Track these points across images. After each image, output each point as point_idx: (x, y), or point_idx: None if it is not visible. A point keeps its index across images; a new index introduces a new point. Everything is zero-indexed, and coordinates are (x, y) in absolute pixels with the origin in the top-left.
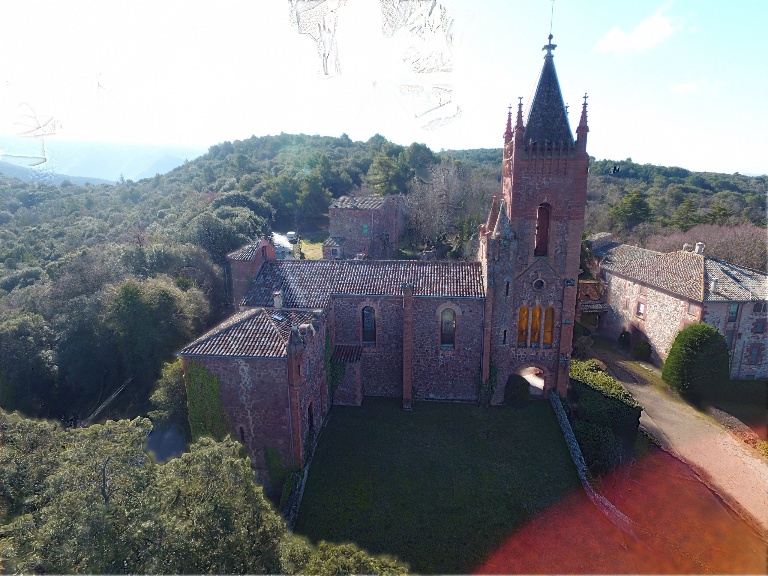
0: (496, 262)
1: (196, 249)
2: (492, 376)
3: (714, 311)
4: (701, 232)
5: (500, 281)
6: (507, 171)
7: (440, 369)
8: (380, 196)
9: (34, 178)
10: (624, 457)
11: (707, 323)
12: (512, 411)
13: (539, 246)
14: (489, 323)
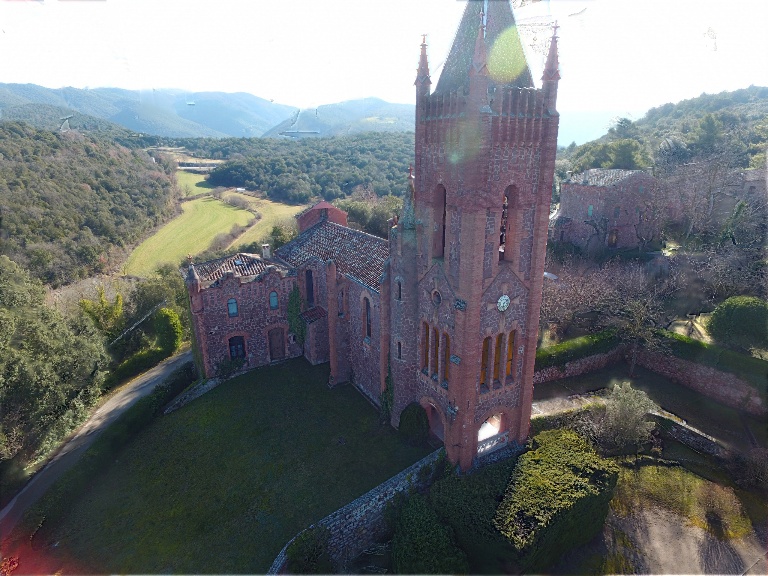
0: None
1: (381, 209)
2: (389, 391)
3: None
4: None
5: (392, 279)
6: None
7: (365, 361)
8: (631, 170)
9: (349, 147)
10: (420, 573)
11: None
12: (394, 441)
13: None
14: (382, 326)
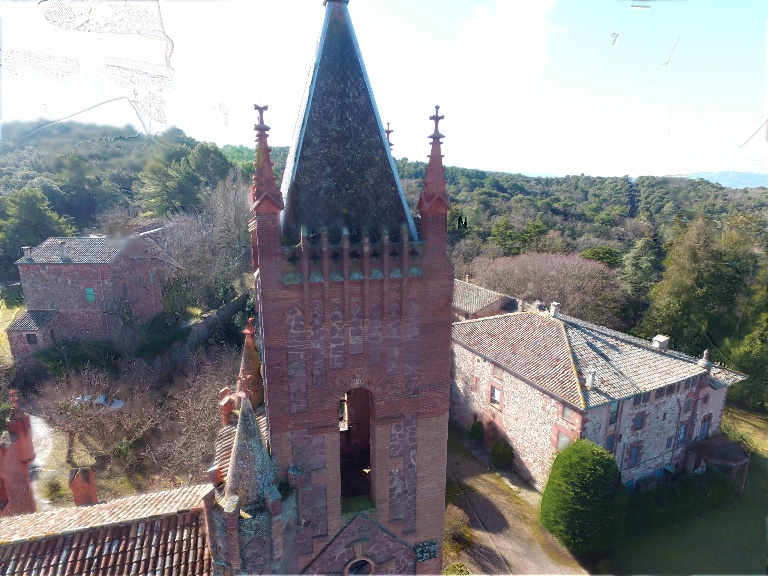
0: (237, 571)
1: None
2: None
3: (595, 416)
4: (530, 261)
5: None
6: None
7: None
8: None
9: None
10: None
11: (588, 434)
12: None
13: (354, 427)
14: None
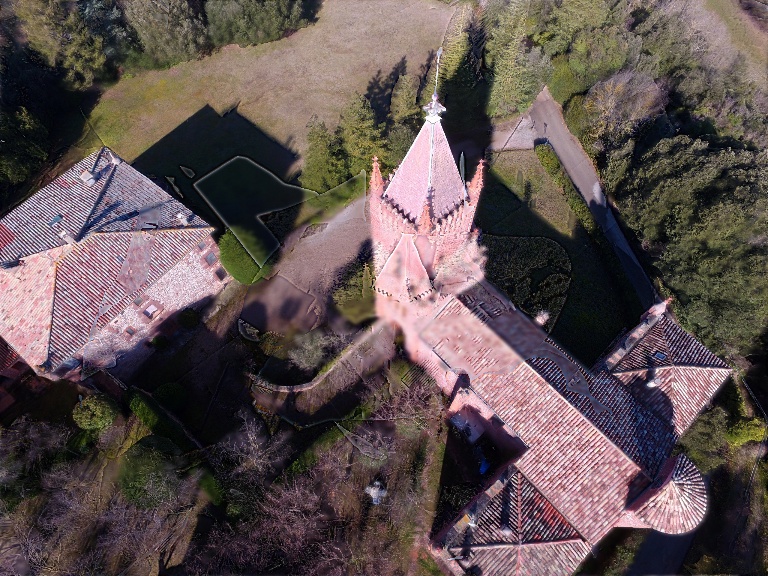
0: None
1: None
2: None
3: None
4: None
5: None
6: None
7: None
8: None
9: None
10: None
11: None
12: None
13: None
14: None
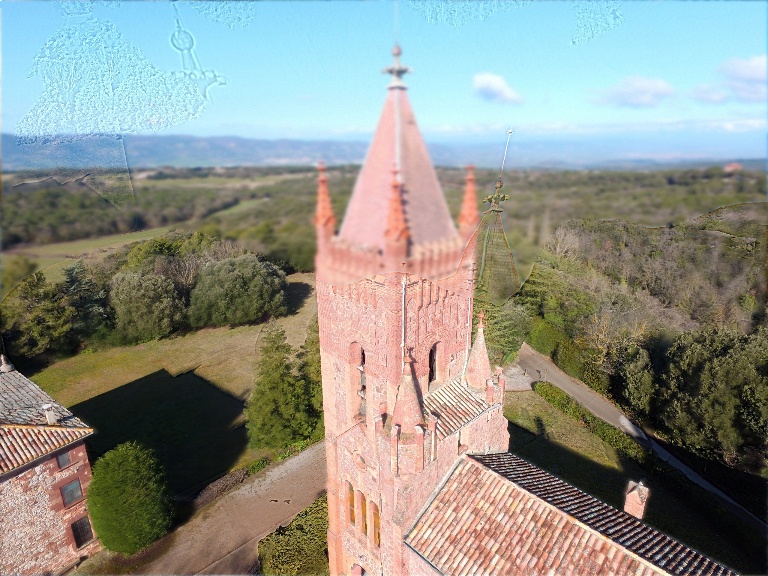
0: None
1: None
2: None
3: None
4: None
5: None
6: None
7: None
8: None
9: None
10: None
11: None
12: None
13: None
14: None
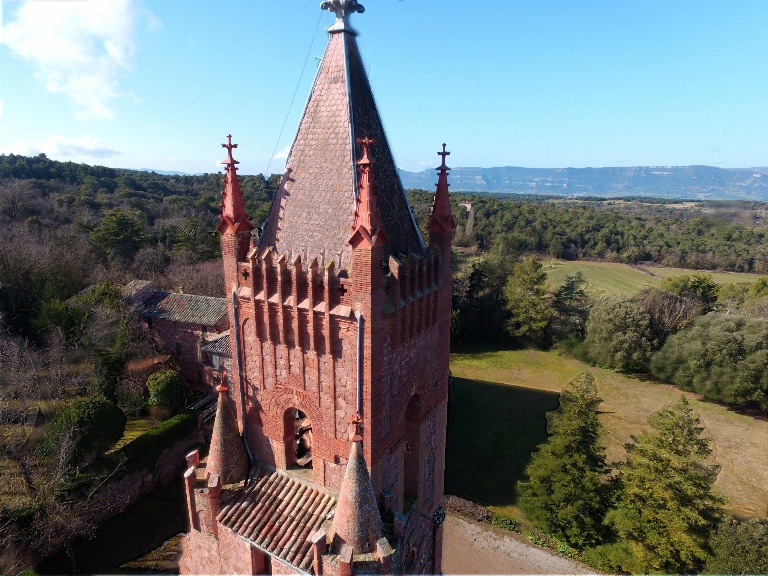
0: None
1: None
2: None
3: None
4: None
5: None
6: (313, 341)
7: None
8: None
9: None
10: None
11: None
12: None
13: None
14: None
